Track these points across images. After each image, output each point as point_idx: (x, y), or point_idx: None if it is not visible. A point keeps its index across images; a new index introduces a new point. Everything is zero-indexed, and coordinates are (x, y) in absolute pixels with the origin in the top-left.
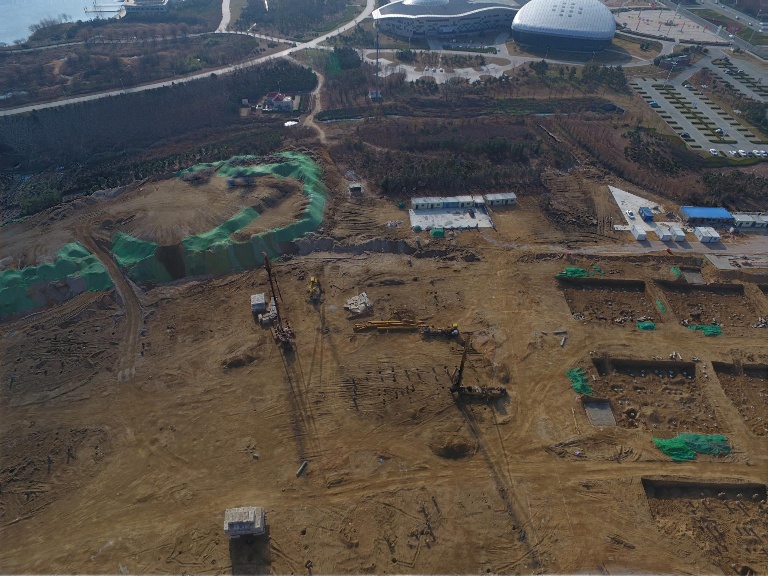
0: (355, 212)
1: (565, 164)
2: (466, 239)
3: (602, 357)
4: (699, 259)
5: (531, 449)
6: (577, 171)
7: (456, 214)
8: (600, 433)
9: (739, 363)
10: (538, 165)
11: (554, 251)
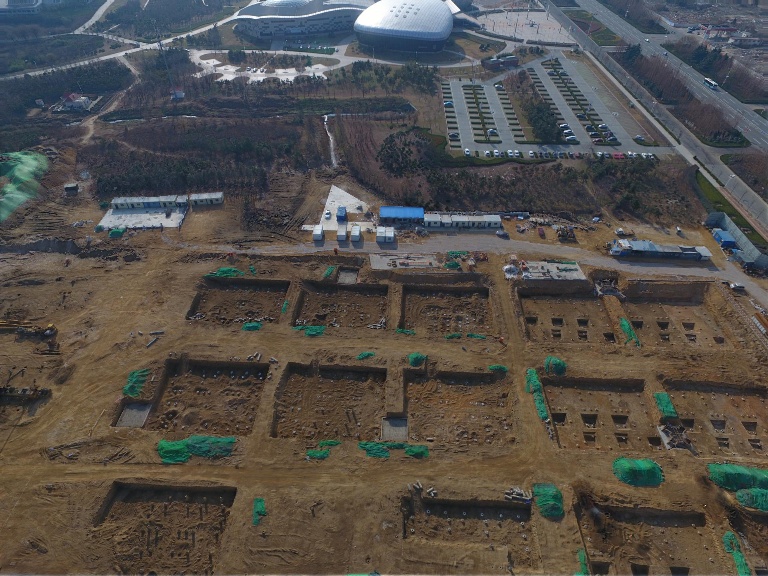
0: (52, 212)
1: (304, 164)
2: (142, 239)
3: (179, 358)
4: (361, 259)
5: (27, 451)
6: (315, 171)
7: (153, 214)
8: (112, 435)
9: (317, 364)
10: (277, 165)
11: (221, 251)
